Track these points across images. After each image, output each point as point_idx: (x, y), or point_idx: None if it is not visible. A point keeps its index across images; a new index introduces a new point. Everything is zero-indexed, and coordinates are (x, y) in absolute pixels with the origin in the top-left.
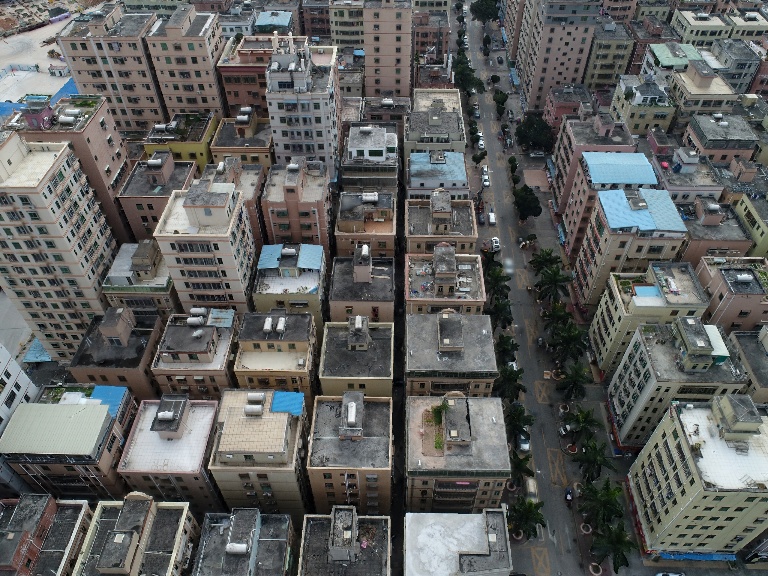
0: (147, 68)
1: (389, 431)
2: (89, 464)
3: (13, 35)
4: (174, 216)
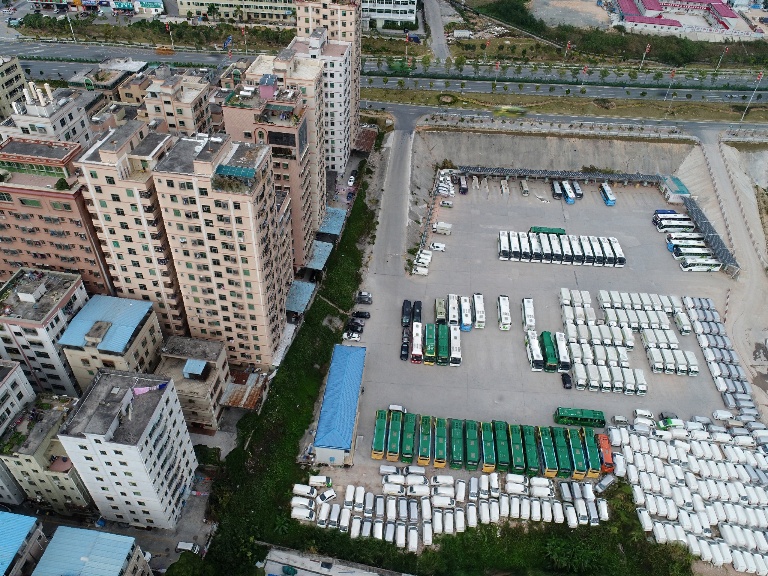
0: None
1: None
2: None
3: None
4: None
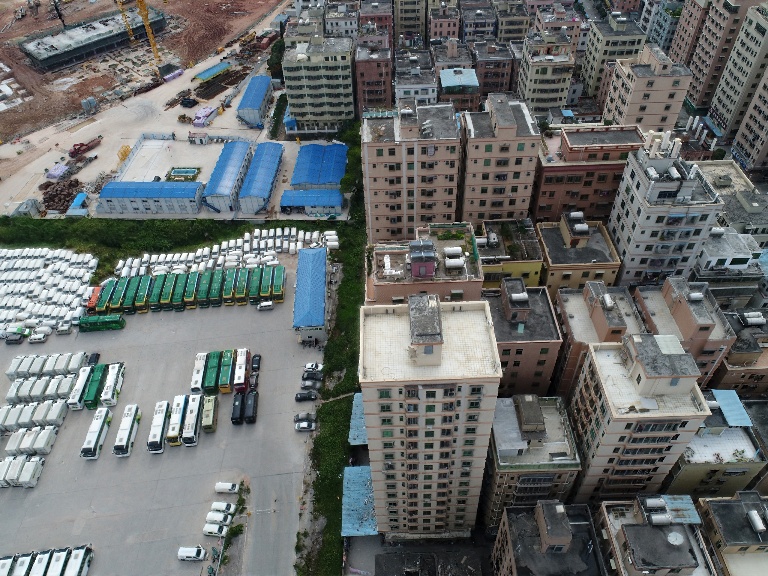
0: (457, 171)
1: None
2: None
3: (130, 98)
4: (609, 381)
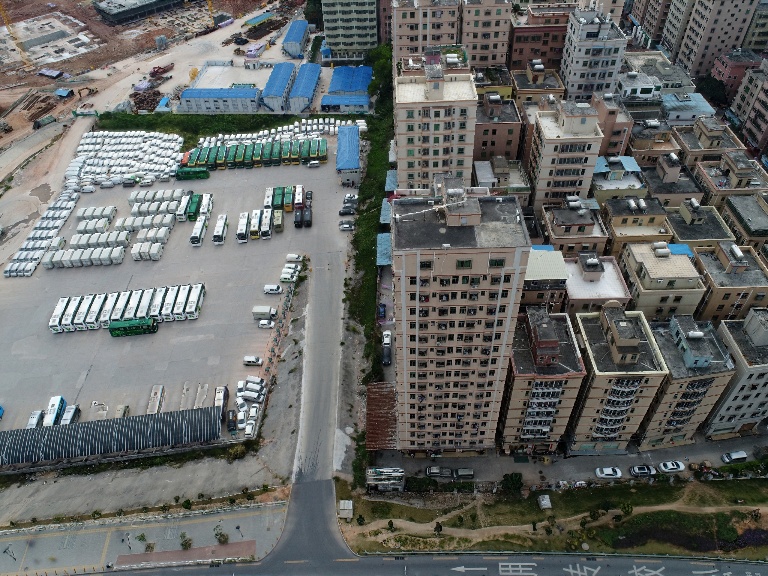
0: (456, 32)
1: (763, 265)
2: (560, 289)
3: (192, 39)
4: (546, 128)
